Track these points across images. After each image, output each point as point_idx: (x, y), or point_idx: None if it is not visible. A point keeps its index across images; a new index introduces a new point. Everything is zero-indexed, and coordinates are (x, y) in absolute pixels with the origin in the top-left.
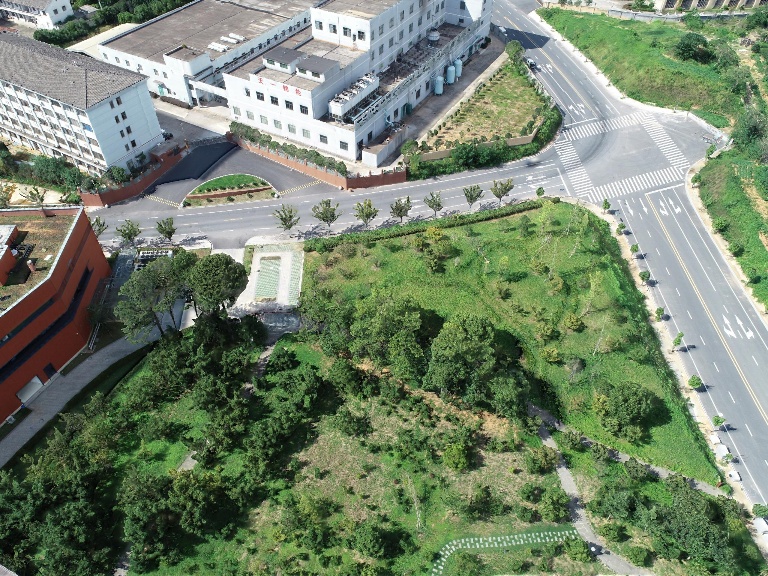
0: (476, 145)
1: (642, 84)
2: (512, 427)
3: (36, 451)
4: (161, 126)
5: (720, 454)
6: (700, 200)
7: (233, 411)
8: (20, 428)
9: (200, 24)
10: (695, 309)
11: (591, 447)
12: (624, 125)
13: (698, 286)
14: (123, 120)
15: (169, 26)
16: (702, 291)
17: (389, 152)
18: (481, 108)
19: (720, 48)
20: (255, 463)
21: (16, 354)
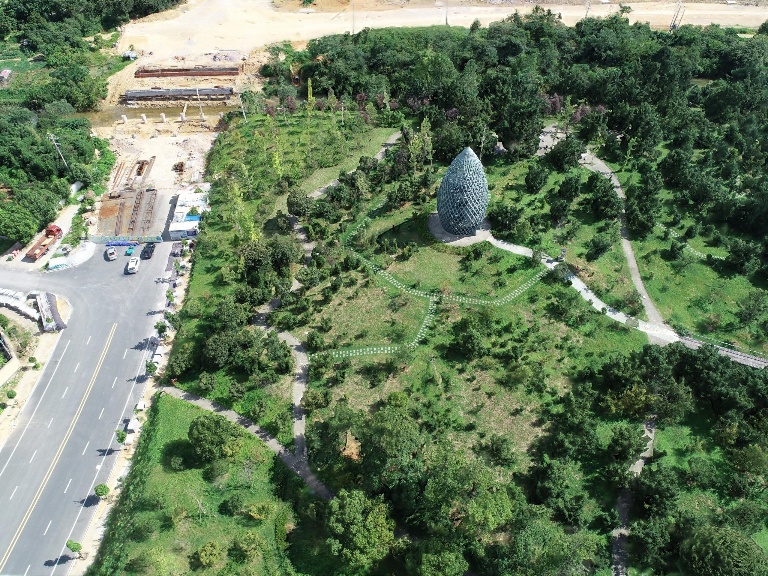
0: None
1: None
2: None
3: None
4: None
5: None
6: None
7: None
8: None
9: None
10: None
11: None
12: None
13: None
14: None
15: None
16: None
17: None
18: None
19: None
20: None
21: None
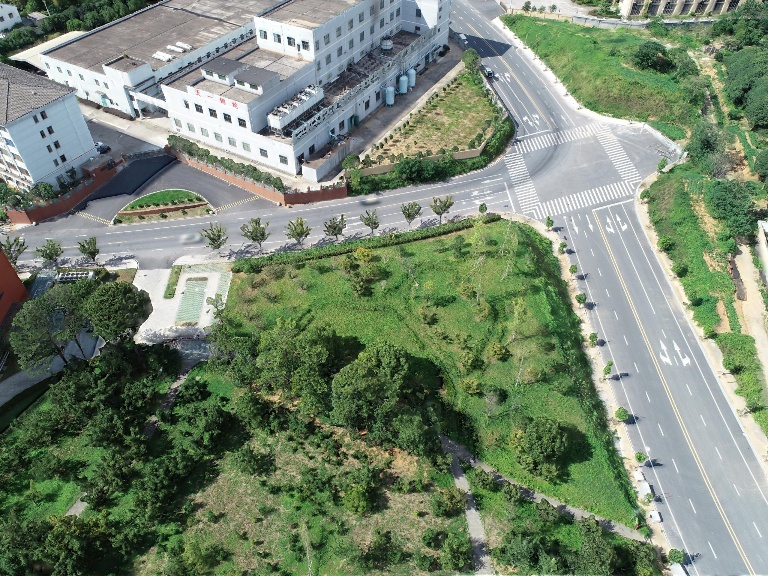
0: (421, 159)
1: (599, 94)
2: (423, 465)
3: None
4: (100, 138)
5: (642, 493)
6: (648, 217)
7: (131, 448)
8: None
9: (148, 32)
10: (632, 334)
11: (504, 487)
12: (578, 137)
13: (637, 309)
14: (50, 135)
15: (116, 34)
16: (641, 314)
17: (331, 166)
18: (432, 119)
19: (679, 57)
20: (144, 507)
21: None
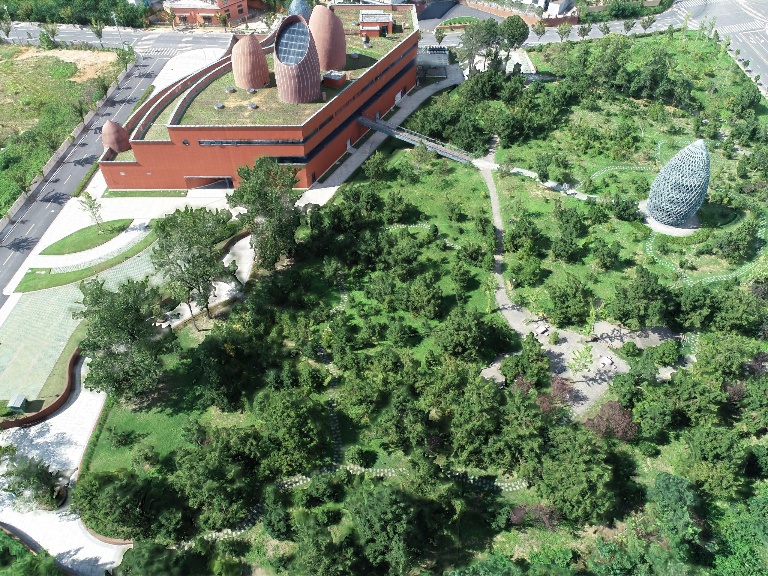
0: (623, 3)
1: None
2: (681, 111)
3: None
4: None
5: None
6: None
7: None
8: (399, 113)
9: None
10: None
11: (726, 119)
12: (720, 1)
13: None
14: None
15: None
16: None
17: (564, 7)
18: None
19: None
20: None
21: (401, 69)
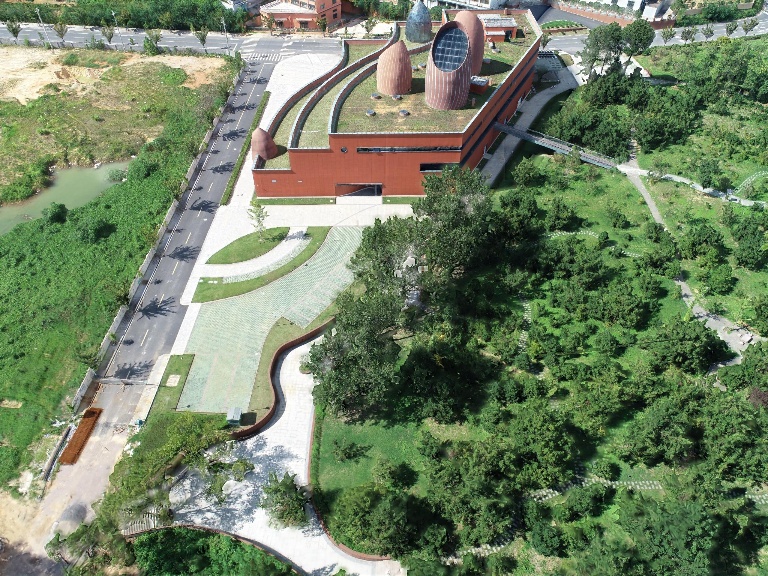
0: (718, 6)
1: None
2: None
3: (554, 117)
4: None
5: None
6: None
7: None
8: (522, 118)
9: None
10: None
11: None
12: None
13: None
14: None
15: None
16: None
17: (658, 10)
18: None
19: None
20: None
21: None
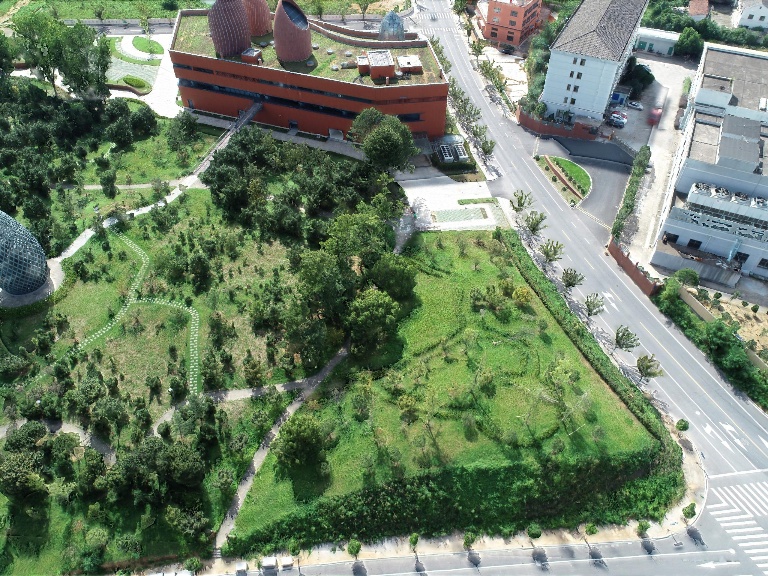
0: (746, 347)
1: None
2: None
3: None
4: (635, 120)
5: None
6: None
7: None
8: (314, 141)
9: None
10: None
11: None
12: None
13: None
14: (577, 78)
15: None
16: None
17: None
18: None
19: None
20: None
21: (339, 109)
